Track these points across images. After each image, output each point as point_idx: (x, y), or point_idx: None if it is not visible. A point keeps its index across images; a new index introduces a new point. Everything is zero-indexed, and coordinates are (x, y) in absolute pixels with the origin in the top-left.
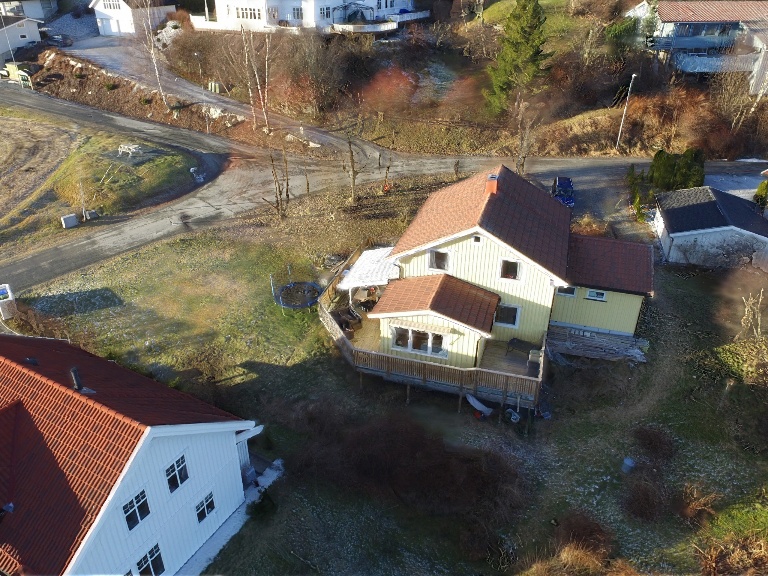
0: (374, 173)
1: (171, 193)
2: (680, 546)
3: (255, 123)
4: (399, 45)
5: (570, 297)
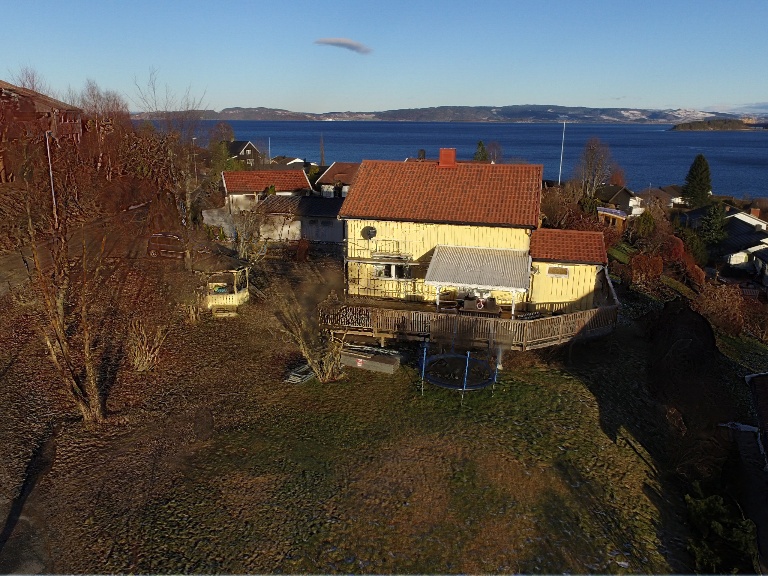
0: None
1: None
2: None
3: None
4: None
5: None
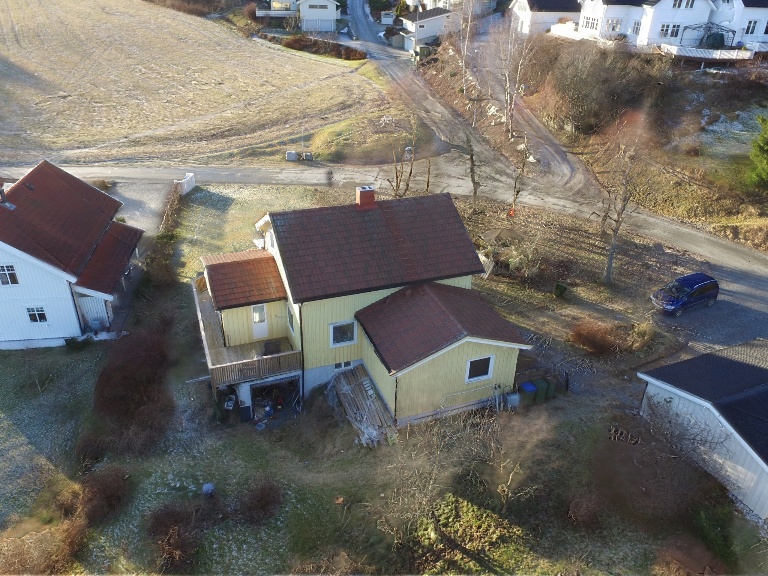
0: (542, 200)
1: (373, 160)
2: (130, 565)
3: (505, 126)
4: (728, 78)
5: (369, 342)
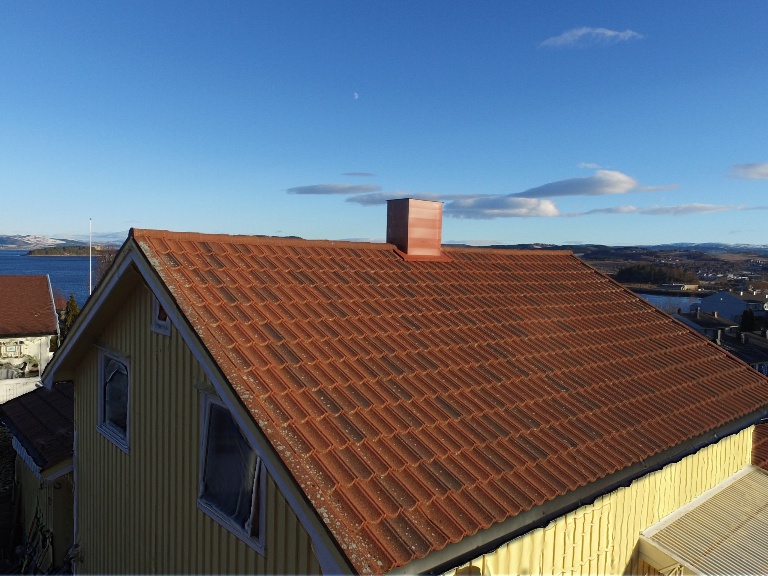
0: None
1: None
2: None
3: None
4: None
5: None
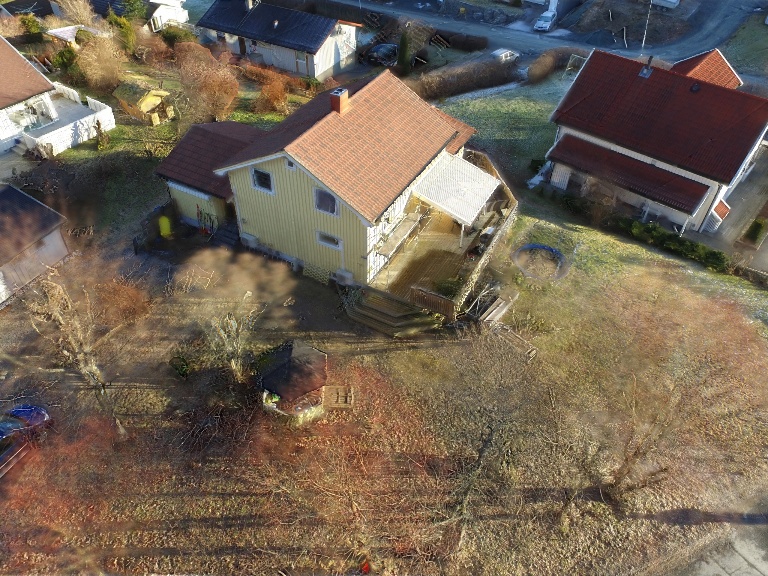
0: None
1: None
2: None
3: None
4: None
5: None
